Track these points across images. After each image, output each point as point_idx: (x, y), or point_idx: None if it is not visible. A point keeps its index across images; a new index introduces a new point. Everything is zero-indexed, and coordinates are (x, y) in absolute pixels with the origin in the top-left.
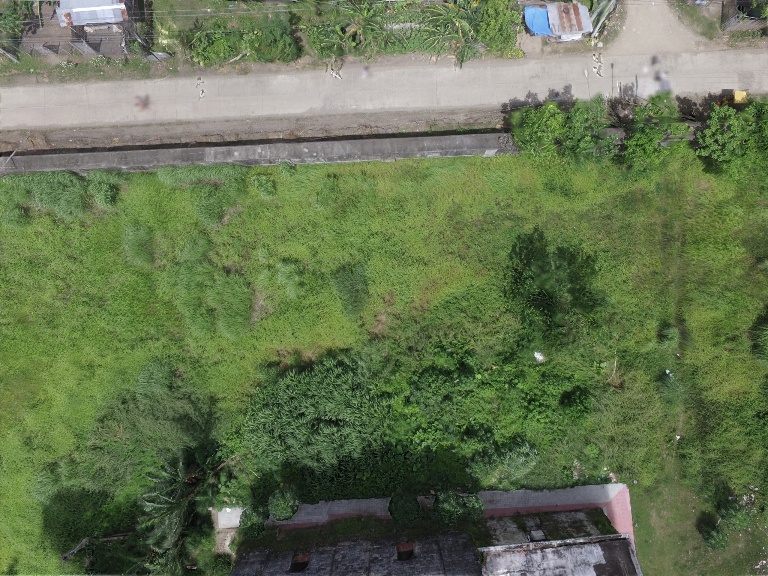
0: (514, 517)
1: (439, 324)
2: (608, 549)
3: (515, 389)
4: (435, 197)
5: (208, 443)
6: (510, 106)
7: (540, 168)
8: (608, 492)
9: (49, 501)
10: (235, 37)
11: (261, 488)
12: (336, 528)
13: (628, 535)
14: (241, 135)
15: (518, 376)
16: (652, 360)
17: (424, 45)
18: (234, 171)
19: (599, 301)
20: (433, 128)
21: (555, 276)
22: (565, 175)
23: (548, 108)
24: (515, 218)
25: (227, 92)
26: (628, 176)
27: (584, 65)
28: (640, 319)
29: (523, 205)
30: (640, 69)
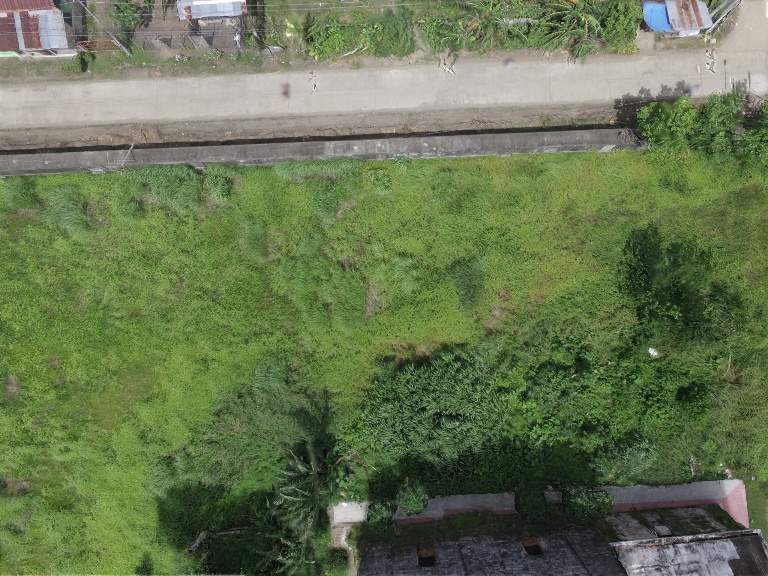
0: (631, 513)
1: (554, 319)
2: (741, 544)
3: (634, 385)
4: (549, 192)
5: (325, 437)
6: (623, 102)
7: (655, 164)
8: (724, 488)
9: (166, 495)
10: (349, 31)
11: (379, 483)
12: (454, 523)
13: (760, 530)
14: (354, 129)
15: (635, 372)
16: (766, 356)
17: (543, 40)
18: (352, 165)
19: (717, 297)
20: (546, 123)
21: (669, 272)
22: (680, 171)
23: (681, 103)
24: (629, 214)
25: (340, 86)
26: (743, 172)
27: (697, 61)
28: (755, 315)
29: (637, 201)
30: (753, 65)
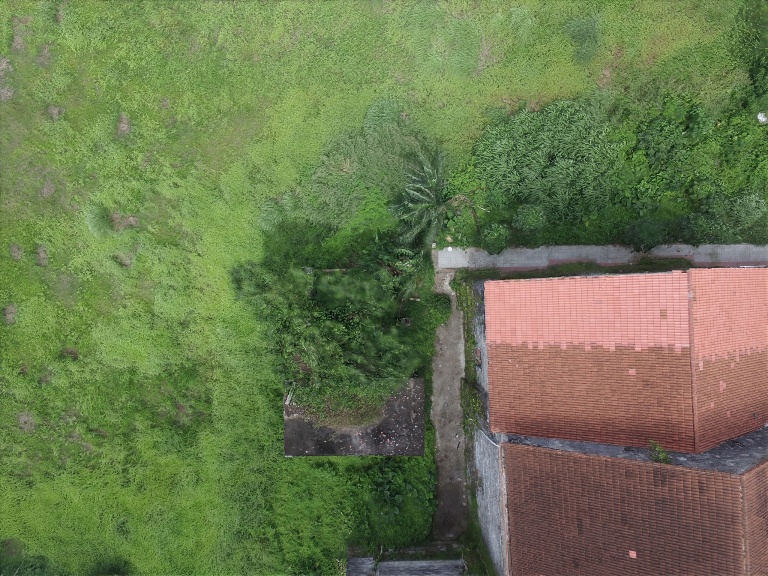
0: None
1: (666, 78)
2: None
3: (746, 139)
4: None
5: None
6: None
7: None
8: None
9: (274, 229)
10: None
11: (487, 225)
12: (559, 269)
13: None
14: None
15: None
16: None
17: None
18: None
19: None
20: None
21: None
22: None
23: None
24: None
25: None
26: None
27: None
28: None
29: None
30: None
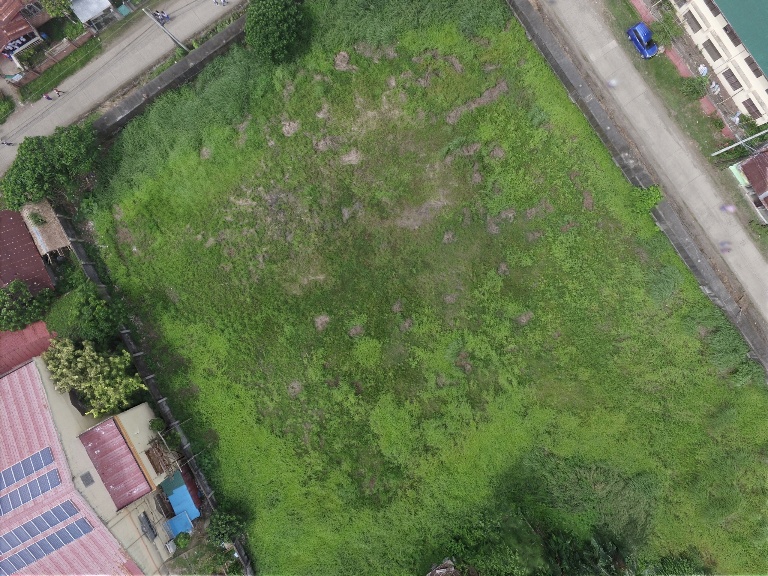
0: None
1: None
2: None
3: None
4: None
5: (627, 547)
6: None
7: None
8: None
9: (529, 469)
10: None
11: None
12: None
13: None
14: None
15: None
16: None
17: None
18: None
19: None
20: None
21: None
22: None
23: None
24: None
25: None
26: None
27: None
28: None
29: None
30: None
